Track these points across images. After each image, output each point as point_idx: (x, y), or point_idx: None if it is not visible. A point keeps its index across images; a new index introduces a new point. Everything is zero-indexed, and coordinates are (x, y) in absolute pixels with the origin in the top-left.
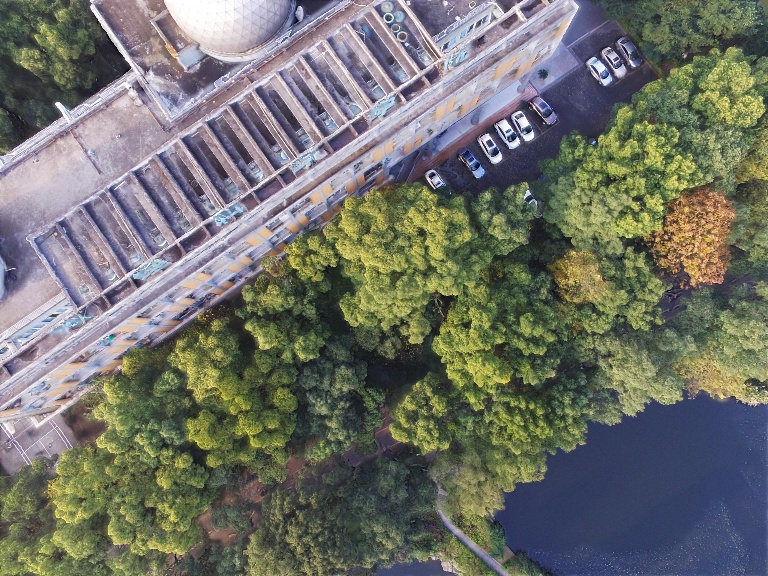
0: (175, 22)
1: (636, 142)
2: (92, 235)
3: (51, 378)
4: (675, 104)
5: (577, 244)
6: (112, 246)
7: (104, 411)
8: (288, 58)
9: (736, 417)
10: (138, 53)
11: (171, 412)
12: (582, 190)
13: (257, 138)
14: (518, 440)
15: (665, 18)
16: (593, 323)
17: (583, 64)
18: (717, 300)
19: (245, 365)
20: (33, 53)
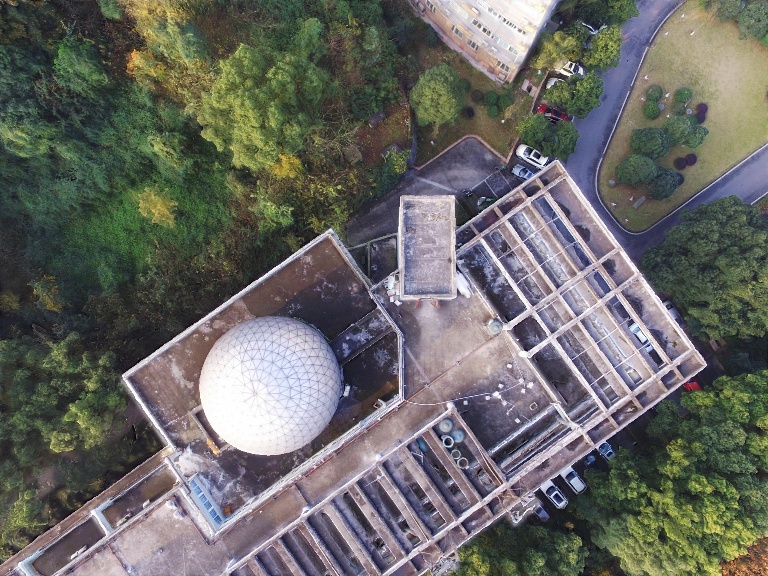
0: None
1: (697, 517)
2: None
3: None
4: (732, 446)
5: (626, 569)
6: None
7: None
8: (339, 463)
9: None
10: (175, 428)
11: None
12: (636, 541)
13: (310, 571)
14: None
15: (714, 306)
16: None
17: None
18: None
19: None
20: (63, 437)
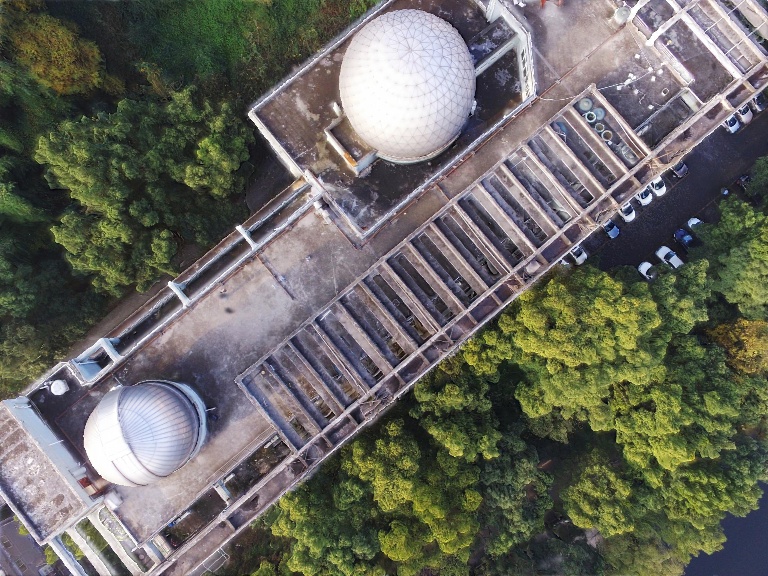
0: (350, 129)
1: None
2: (302, 371)
3: None
4: None
5: (745, 311)
6: (325, 381)
7: (285, 529)
8: (478, 161)
9: None
10: (305, 160)
11: (358, 525)
12: (761, 262)
13: (464, 254)
14: (698, 514)
15: None
16: None
17: None
18: None
19: (426, 468)
20: (197, 170)
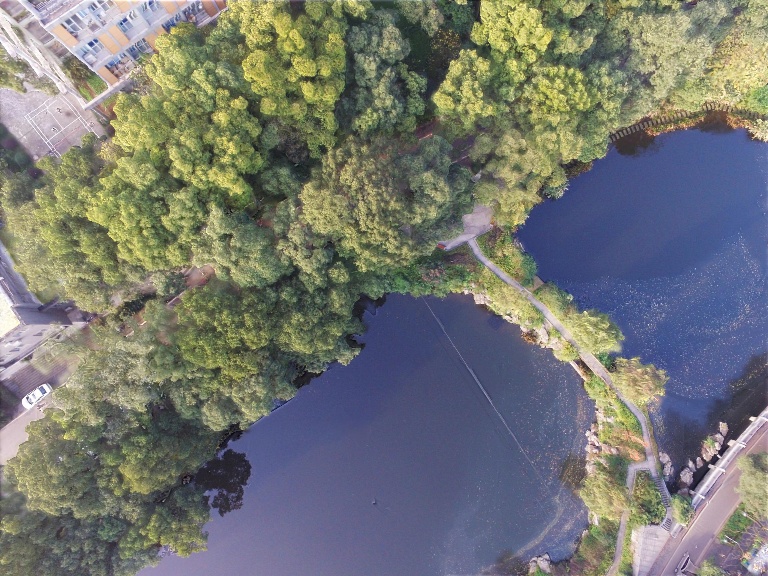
0: None
1: None
2: None
3: (106, 14)
4: None
5: None
6: None
7: (157, 62)
8: None
9: (752, 153)
10: None
11: (225, 57)
12: None
13: None
14: (557, 112)
15: None
16: None
17: None
18: None
19: None
20: None
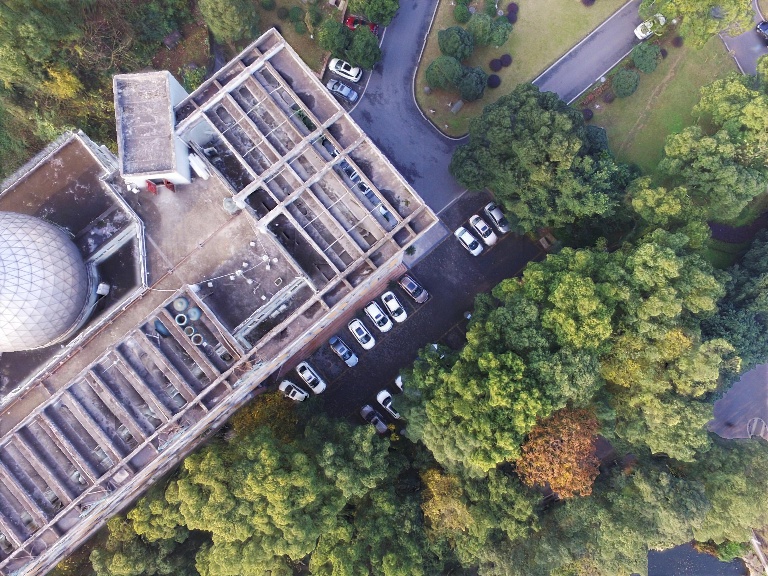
0: None
1: (476, 388)
2: None
3: None
4: (524, 322)
5: (442, 462)
6: None
7: None
8: (85, 357)
9: None
10: None
11: None
12: (433, 425)
13: (51, 464)
14: None
15: (524, 196)
16: (464, 546)
17: (452, 234)
18: (597, 490)
19: None
20: None
